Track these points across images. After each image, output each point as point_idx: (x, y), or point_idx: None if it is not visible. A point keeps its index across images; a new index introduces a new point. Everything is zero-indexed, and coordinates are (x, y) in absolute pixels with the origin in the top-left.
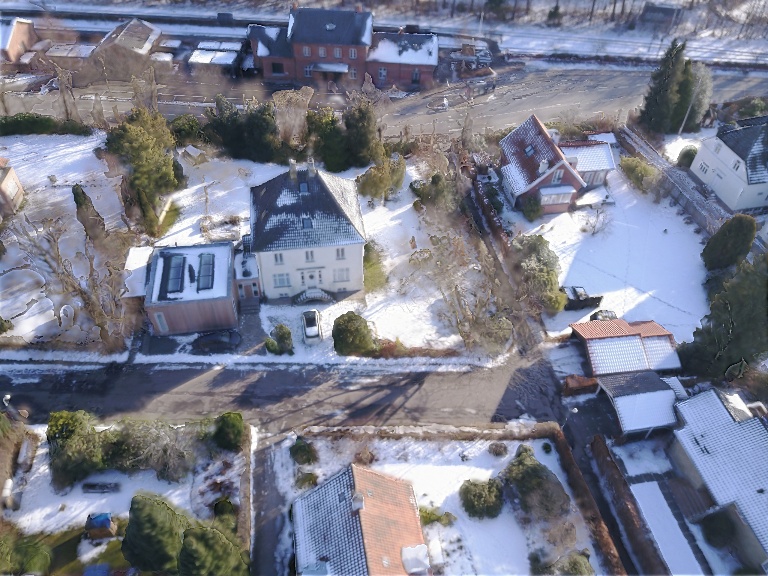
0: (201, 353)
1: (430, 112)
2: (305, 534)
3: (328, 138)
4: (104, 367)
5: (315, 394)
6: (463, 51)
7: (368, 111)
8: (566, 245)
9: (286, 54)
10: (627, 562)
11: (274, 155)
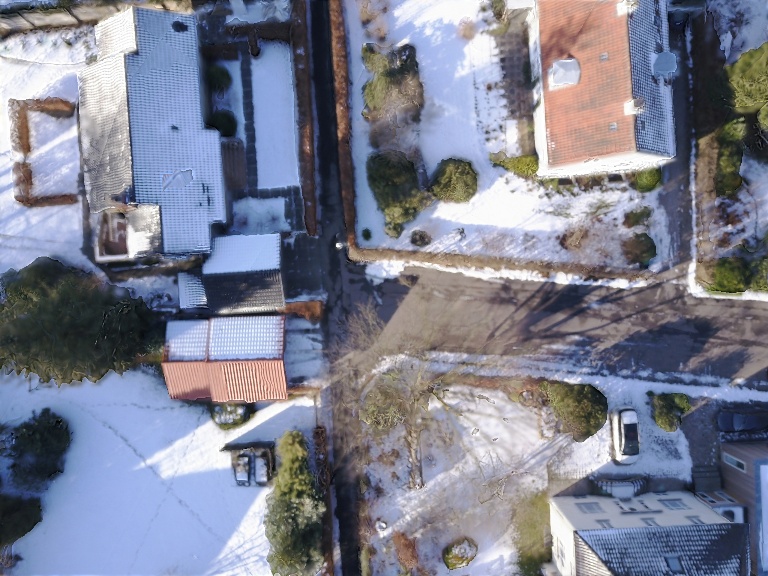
0: (763, 405)
1: None
2: (667, 117)
3: None
4: None
5: (621, 332)
6: None
7: None
8: (230, 572)
9: None
10: (323, 110)
11: None
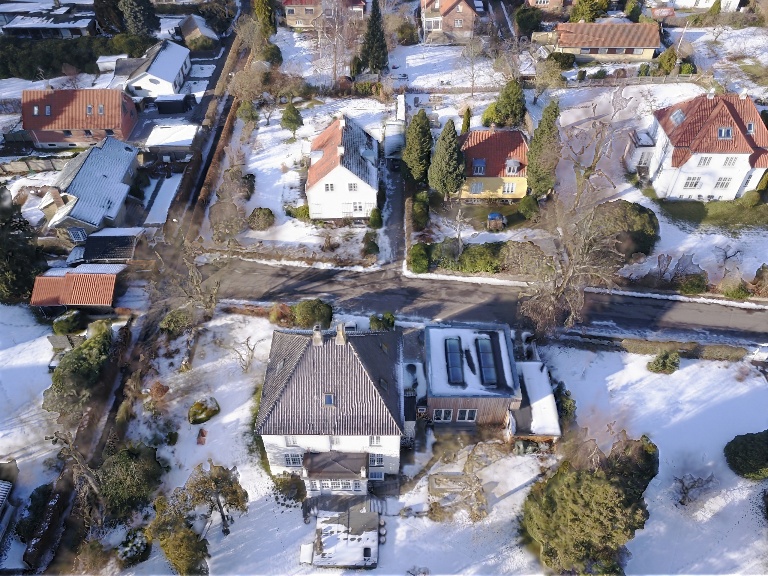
0: None
1: None
2: (372, 175)
3: None
4: None
5: (356, 292)
6: None
7: None
8: (8, 430)
9: None
10: None
11: None
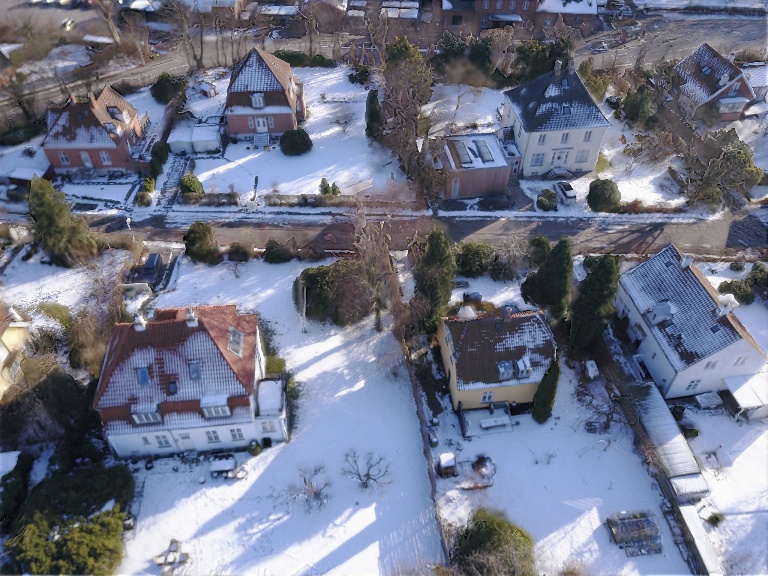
0: (487, 210)
1: (594, 53)
2: (639, 292)
3: (538, 63)
4: (418, 218)
5: (584, 235)
6: (608, 6)
7: (569, 41)
8: None
9: (467, 7)
10: None
11: (488, 80)
